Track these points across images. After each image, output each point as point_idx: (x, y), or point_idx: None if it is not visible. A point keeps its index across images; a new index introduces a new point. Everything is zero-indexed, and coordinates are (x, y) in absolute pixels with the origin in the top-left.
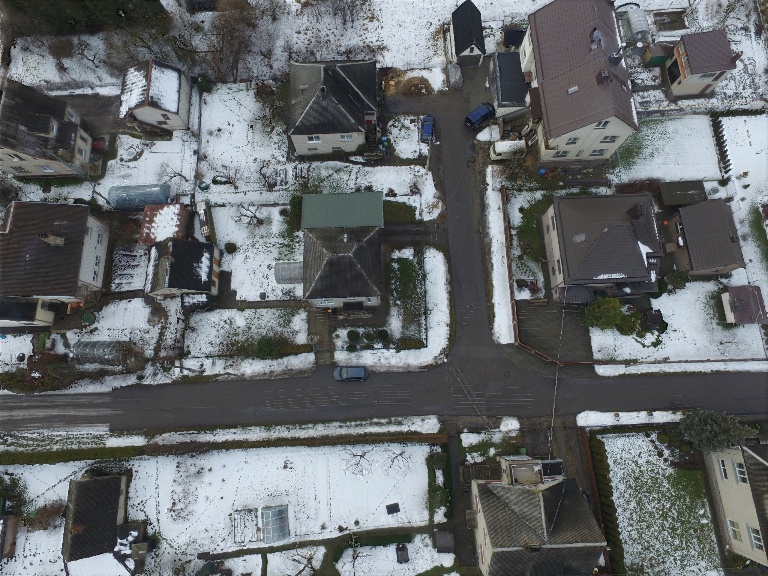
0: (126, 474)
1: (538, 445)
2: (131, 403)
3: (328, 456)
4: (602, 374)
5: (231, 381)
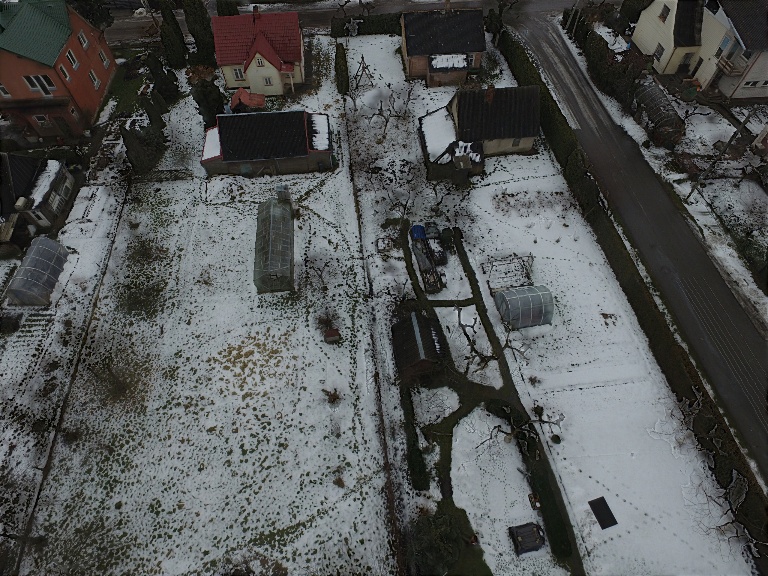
0: None
1: None
2: (613, 142)
3: (649, 379)
4: None
5: (694, 234)
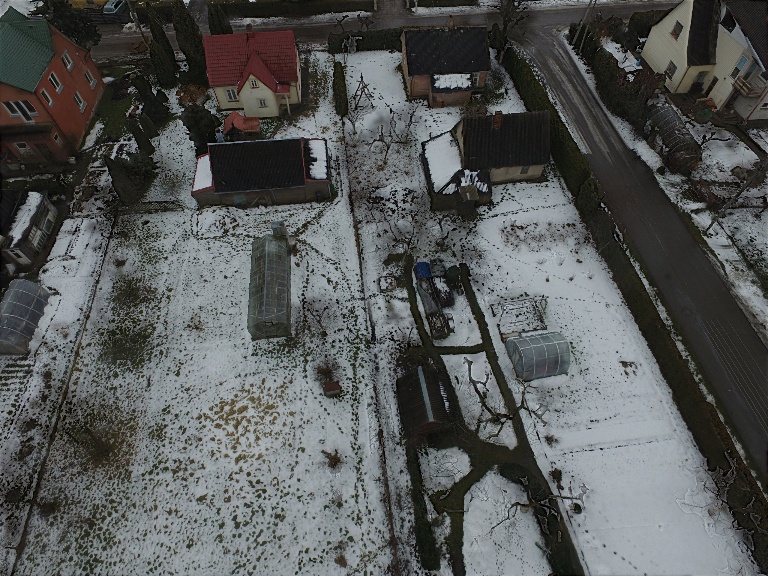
0: (542, 176)
1: None
2: (626, 168)
3: (674, 437)
4: None
5: (715, 270)
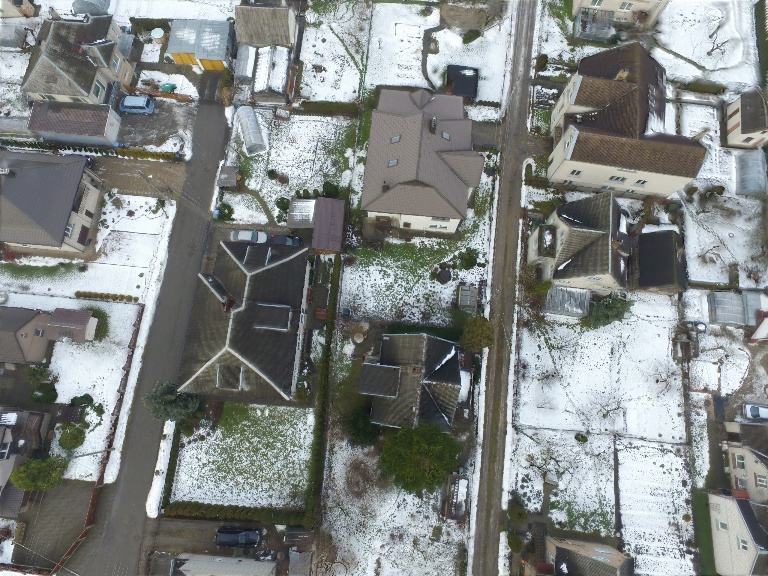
0: None
1: (167, 567)
2: None
3: None
4: (115, 477)
5: None
